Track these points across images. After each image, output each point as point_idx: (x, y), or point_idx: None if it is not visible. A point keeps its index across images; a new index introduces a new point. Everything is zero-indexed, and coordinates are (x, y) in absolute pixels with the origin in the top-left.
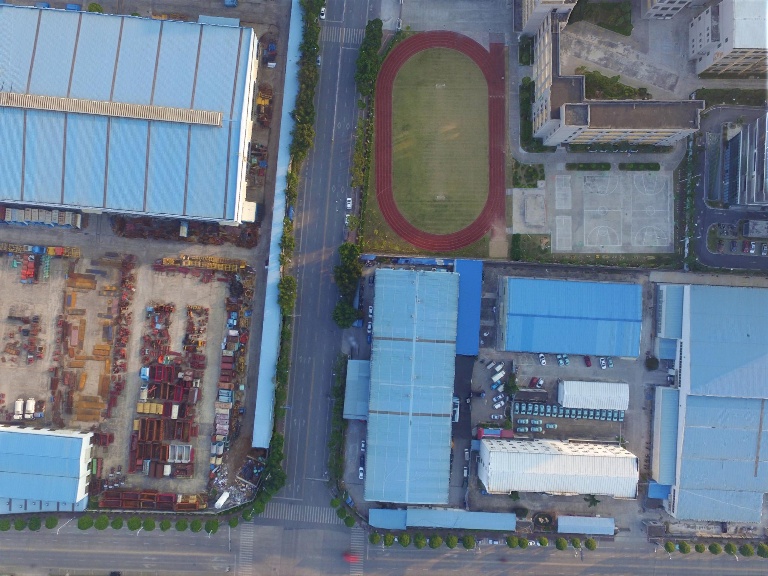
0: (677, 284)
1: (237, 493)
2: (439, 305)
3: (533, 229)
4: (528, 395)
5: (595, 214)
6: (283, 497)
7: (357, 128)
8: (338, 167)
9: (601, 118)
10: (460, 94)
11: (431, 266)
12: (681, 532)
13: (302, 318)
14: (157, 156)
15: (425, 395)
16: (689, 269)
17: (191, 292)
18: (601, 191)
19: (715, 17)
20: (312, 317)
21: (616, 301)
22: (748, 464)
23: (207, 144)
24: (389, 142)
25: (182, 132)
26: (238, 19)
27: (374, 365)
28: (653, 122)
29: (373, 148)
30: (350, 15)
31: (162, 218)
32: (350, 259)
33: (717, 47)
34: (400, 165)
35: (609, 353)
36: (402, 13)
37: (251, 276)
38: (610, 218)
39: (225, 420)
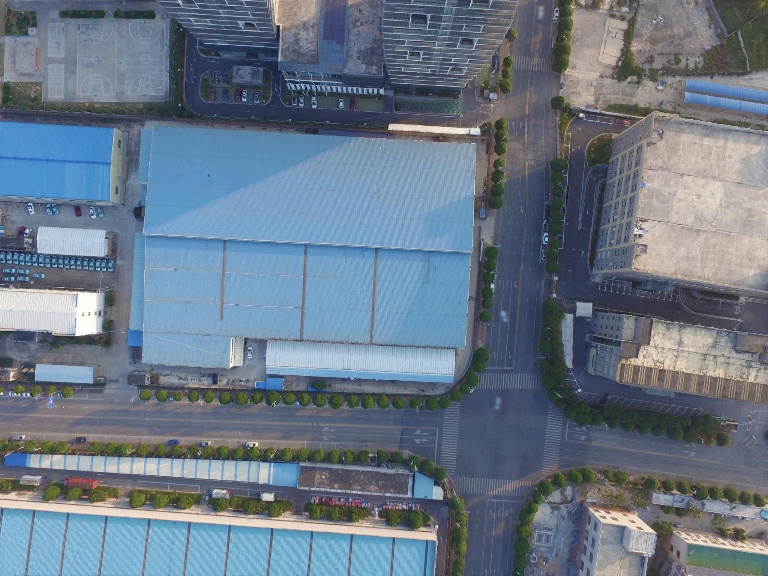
0: None
1: None
2: None
3: (24, 77)
4: (4, 241)
5: (89, 62)
6: None
7: None
8: None
9: None
10: None
11: None
12: (172, 384)
13: None
14: None
15: None
16: (174, 116)
17: None
18: (95, 39)
19: None
20: None
21: (86, 144)
22: (213, 307)
23: None
24: None
25: None
26: None
27: None
28: None
29: None
30: None
31: None
32: None
33: None
34: None
35: (79, 196)
36: None
37: None
38: (104, 66)
39: None
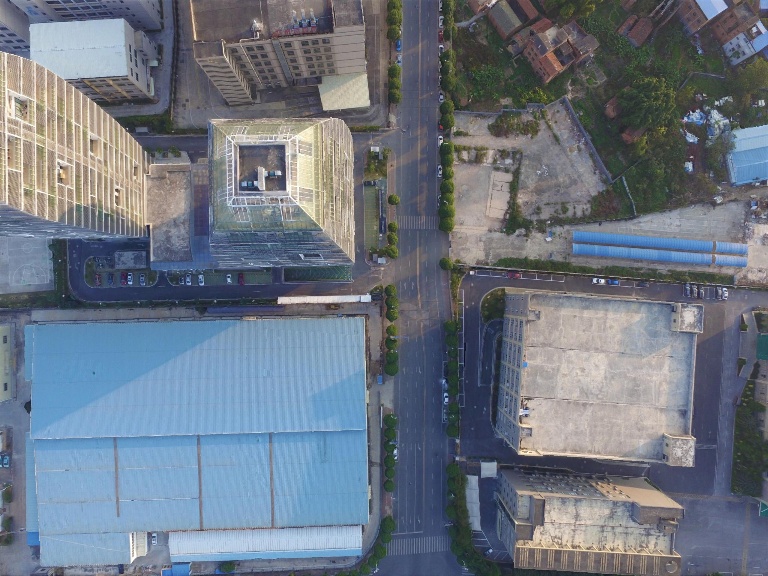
0: (58, 322)
1: None
2: None
3: None
4: None
5: None
6: None
7: None
8: None
9: None
10: None
11: None
12: None
13: None
14: None
15: None
16: (59, 306)
17: None
18: None
19: None
20: None
21: None
22: (108, 505)
23: None
24: None
25: None
26: None
27: None
28: None
29: None
30: None
31: None
32: None
33: None
34: None
35: None
36: None
37: None
38: None
39: None
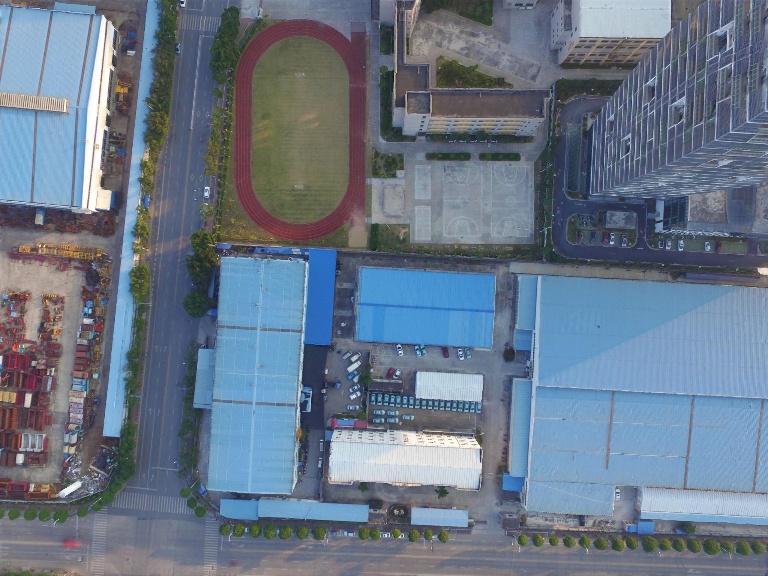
0: (537, 275)
1: (90, 482)
2: (284, 294)
3: (392, 219)
4: (382, 386)
5: (455, 204)
6: (137, 487)
7: (212, 116)
8: (197, 156)
9: (447, 107)
10: (321, 83)
11: (288, 255)
12: (538, 525)
13: (159, 307)
14: (4, 143)
15: (269, 384)
16: (546, 260)
17: (47, 280)
18: (461, 181)
19: (568, 6)
20: (169, 306)
21: (469, 291)
22: (599, 456)
23: (54, 131)
24: (248, 131)
25: (29, 119)
26: (94, 6)
27: (218, 354)
28: (499, 111)
29: (232, 137)
30: (211, 3)
31: (19, 206)
32: (202, 248)
33: (570, 36)
34: (259, 154)
35: (461, 344)
36: (263, 2)
37: (108, 264)
38: (470, 208)
39: (79, 409)
